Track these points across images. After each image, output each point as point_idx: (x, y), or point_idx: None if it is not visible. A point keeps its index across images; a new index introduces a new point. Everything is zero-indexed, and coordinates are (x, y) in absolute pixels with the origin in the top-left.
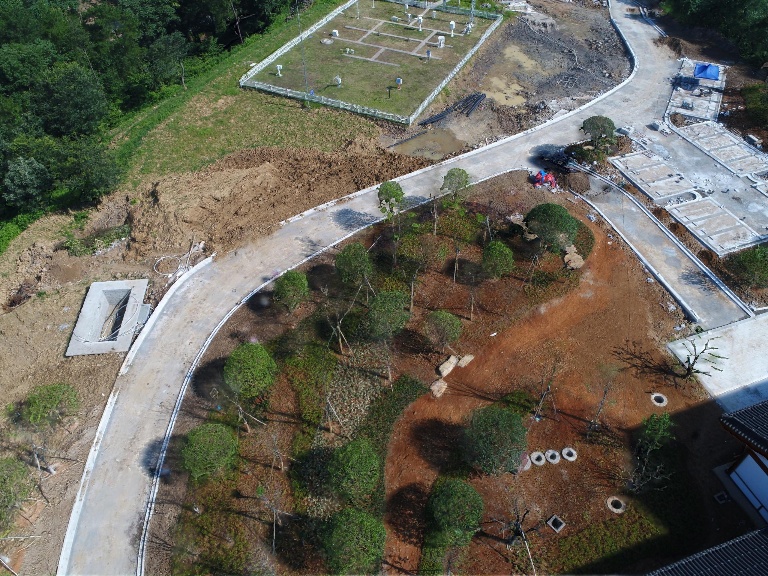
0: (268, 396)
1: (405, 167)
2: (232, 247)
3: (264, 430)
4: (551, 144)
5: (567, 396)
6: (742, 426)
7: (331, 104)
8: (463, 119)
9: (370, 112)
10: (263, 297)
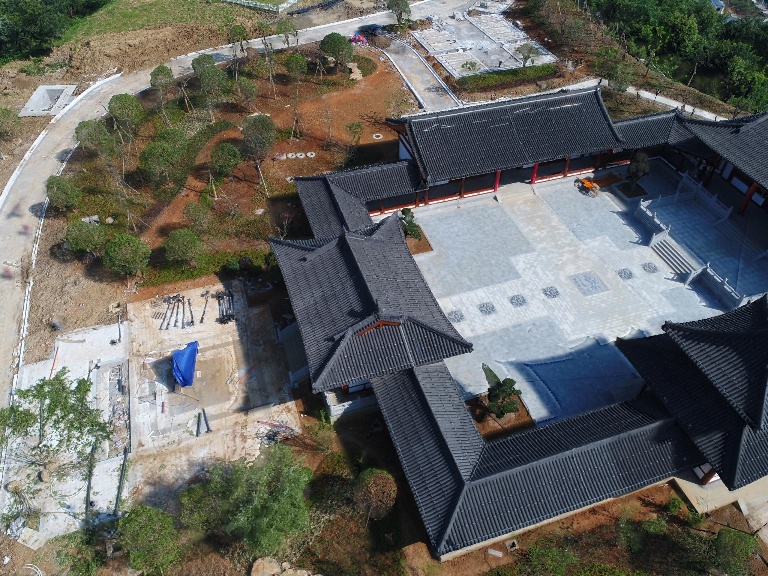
0: (139, 130)
1: (266, 33)
2: (135, 69)
3: (132, 143)
4: (376, 24)
5: (320, 131)
6: (392, 120)
7: (227, 0)
8: (322, 12)
9: (253, 4)
10: (149, 91)
